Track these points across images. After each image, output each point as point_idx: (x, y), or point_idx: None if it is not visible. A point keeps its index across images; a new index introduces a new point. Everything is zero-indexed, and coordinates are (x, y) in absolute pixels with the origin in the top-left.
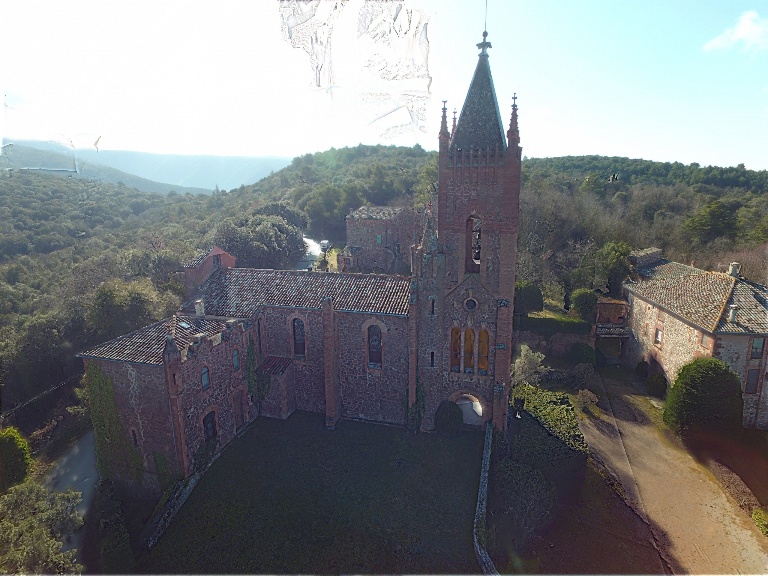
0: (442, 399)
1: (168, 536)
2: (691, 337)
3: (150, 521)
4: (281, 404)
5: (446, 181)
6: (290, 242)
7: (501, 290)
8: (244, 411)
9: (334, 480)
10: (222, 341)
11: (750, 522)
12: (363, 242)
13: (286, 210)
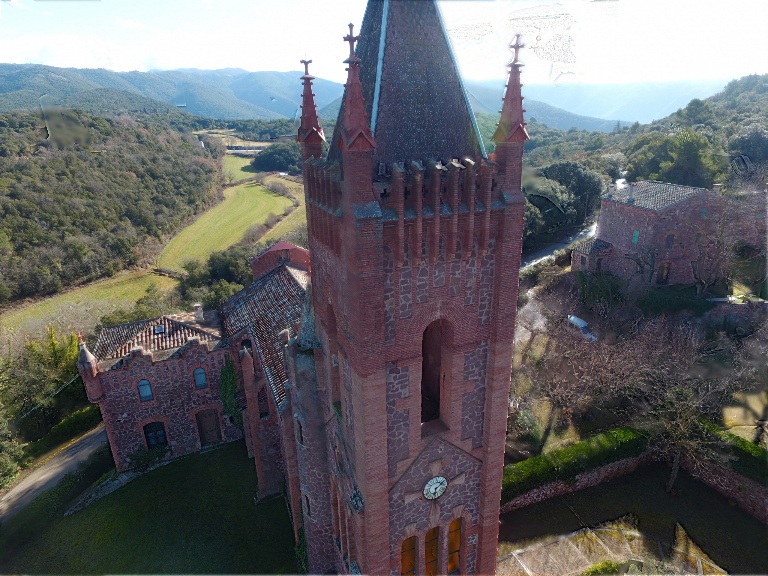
0: (335, 567)
1: (78, 515)
2: None
3: (83, 493)
4: (246, 440)
5: (310, 226)
6: (556, 216)
7: (358, 473)
8: (220, 429)
9: (173, 570)
10: (170, 358)
11: None
12: (615, 237)
13: (577, 172)
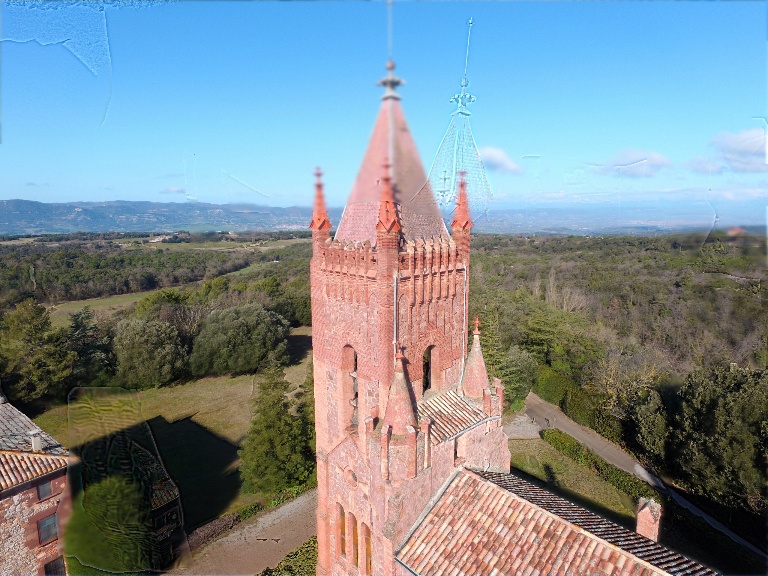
0: None
1: None
2: (7, 513)
3: None
4: None
5: None
6: None
7: None
8: None
9: None
10: None
11: (246, 521)
12: None
13: None
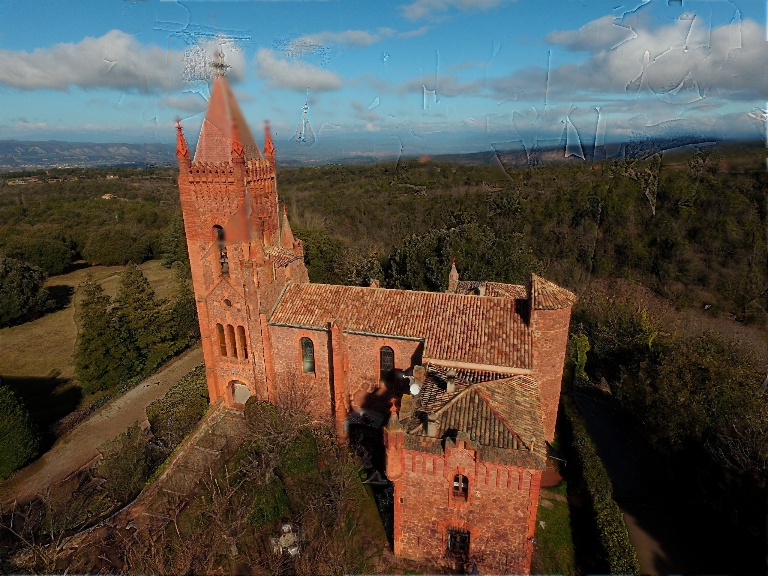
0: None
1: None
2: None
3: None
4: None
5: None
6: None
7: None
8: None
9: None
10: None
11: None
12: None
13: None
